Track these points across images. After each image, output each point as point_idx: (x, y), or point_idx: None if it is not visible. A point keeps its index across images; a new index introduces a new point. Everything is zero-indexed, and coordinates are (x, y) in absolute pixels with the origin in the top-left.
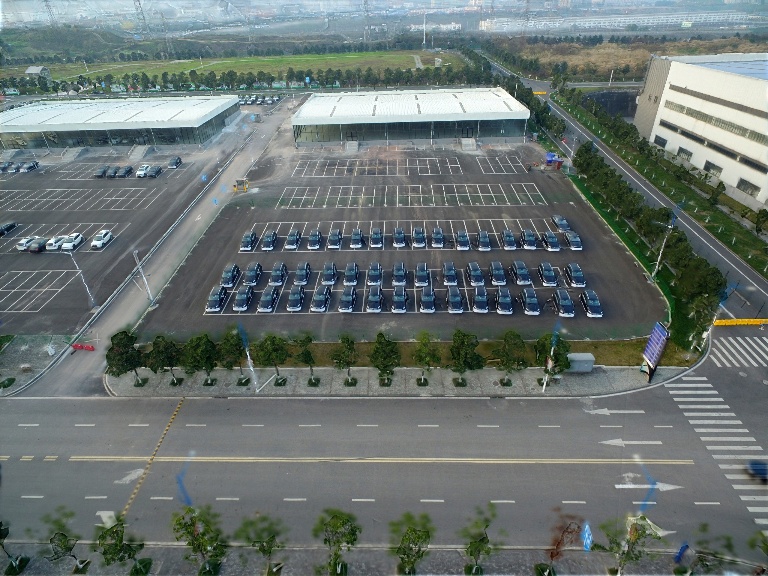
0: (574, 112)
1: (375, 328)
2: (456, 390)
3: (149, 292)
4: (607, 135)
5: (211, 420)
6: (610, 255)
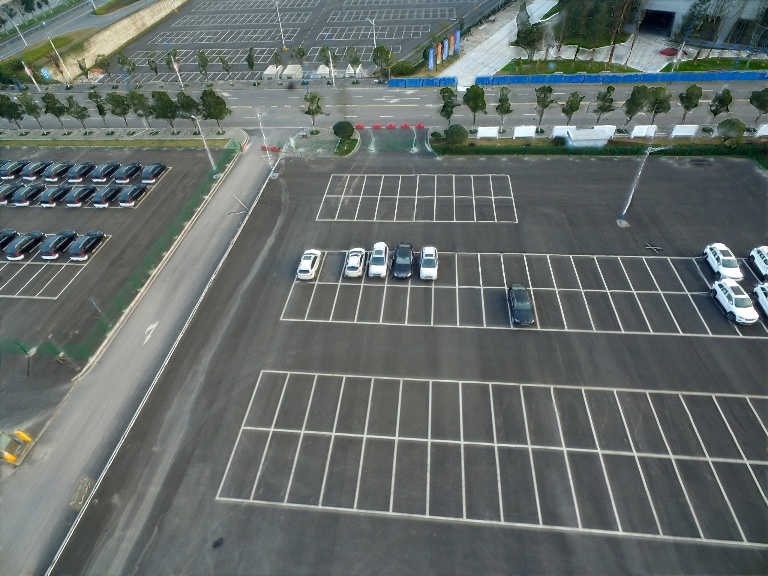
0: None
1: (40, 155)
2: (31, 131)
3: (211, 161)
4: None
5: (178, 119)
6: None
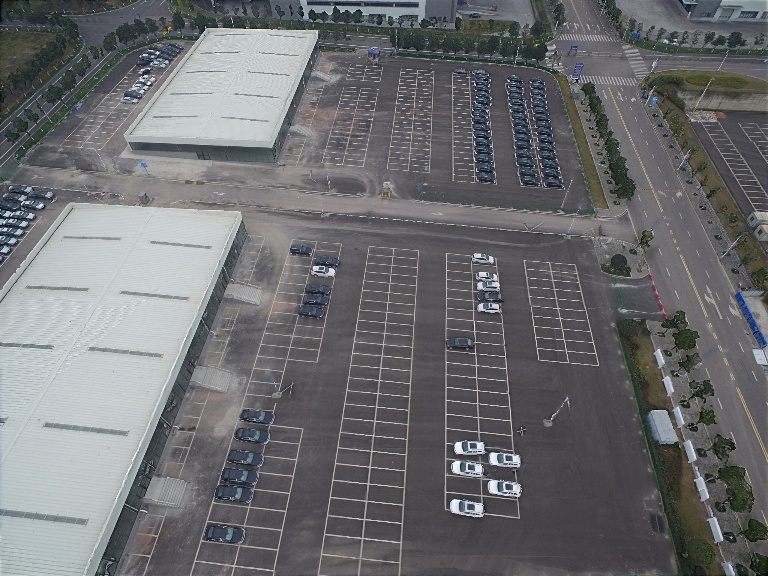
0: (257, 22)
1: (564, 135)
2: None
3: None
4: (320, 26)
5: None
6: (492, 69)
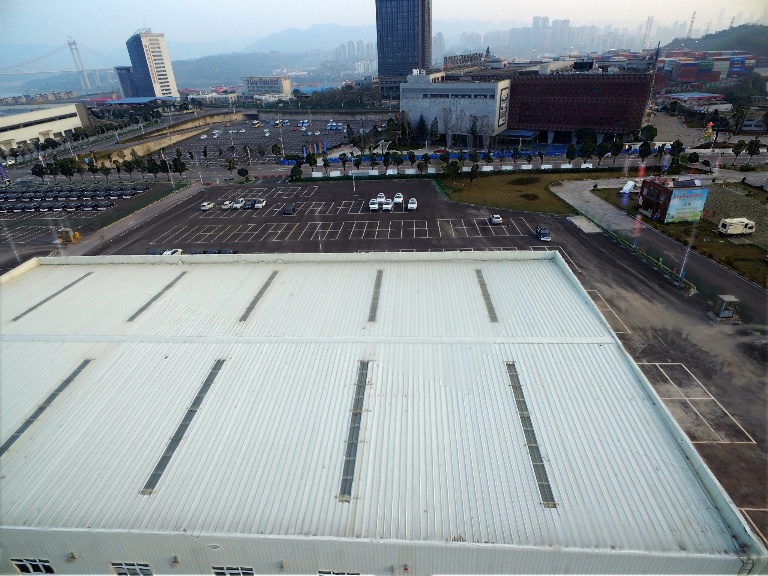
0: None
1: None
2: None
3: (172, 182)
4: None
5: (160, 177)
6: None
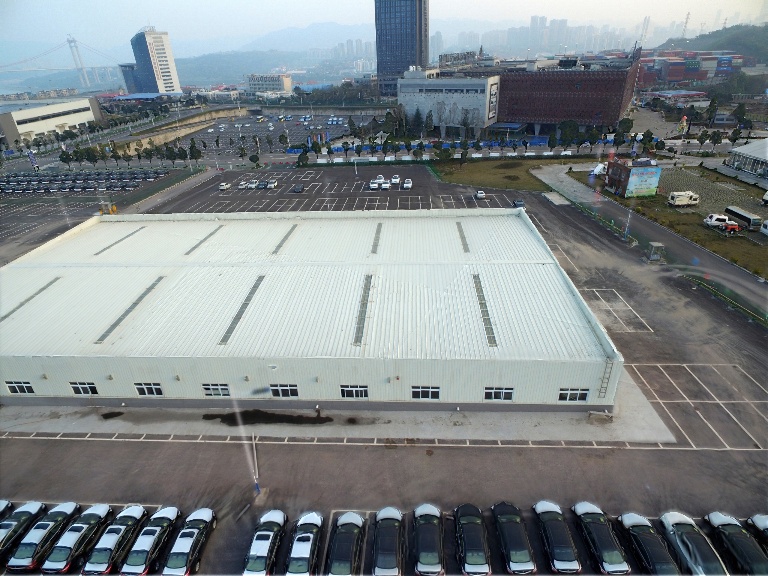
0: None
1: None
2: None
3: None
4: None
5: (177, 164)
6: None
